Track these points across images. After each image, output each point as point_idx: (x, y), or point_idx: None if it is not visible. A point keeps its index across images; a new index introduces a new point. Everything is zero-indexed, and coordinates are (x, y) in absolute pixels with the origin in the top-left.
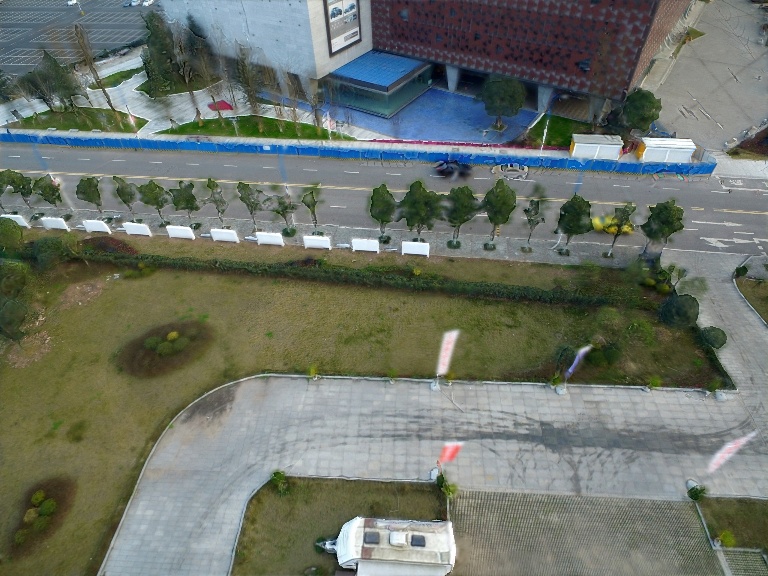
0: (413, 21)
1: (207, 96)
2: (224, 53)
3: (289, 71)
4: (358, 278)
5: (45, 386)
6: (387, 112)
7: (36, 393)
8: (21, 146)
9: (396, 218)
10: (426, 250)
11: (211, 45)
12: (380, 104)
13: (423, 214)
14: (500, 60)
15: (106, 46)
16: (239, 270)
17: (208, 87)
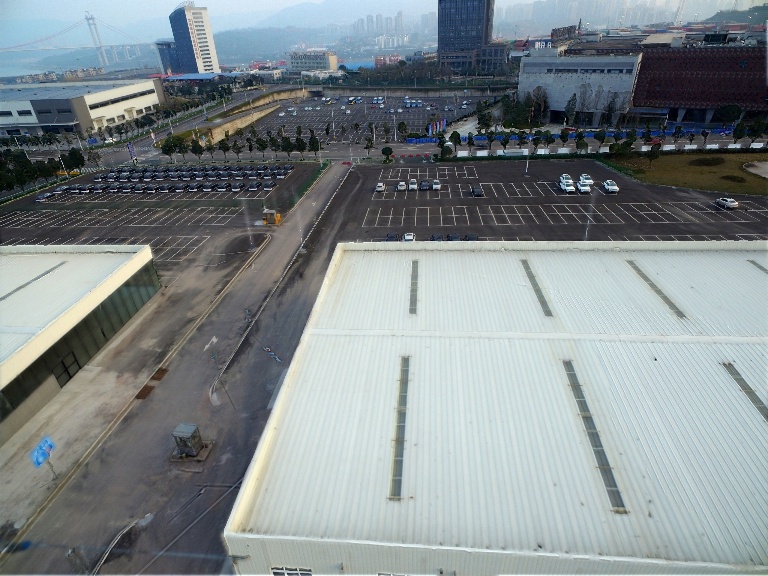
0: (663, 89)
1: (552, 128)
2: (604, 96)
3: (605, 112)
4: (751, 148)
5: (676, 170)
6: (661, 127)
7: (676, 171)
8: (498, 141)
9: (746, 135)
10: (761, 146)
11: (598, 93)
12: (656, 124)
13: (764, 129)
14: (716, 101)
15: (414, 126)
16: (694, 153)
17: (545, 126)
